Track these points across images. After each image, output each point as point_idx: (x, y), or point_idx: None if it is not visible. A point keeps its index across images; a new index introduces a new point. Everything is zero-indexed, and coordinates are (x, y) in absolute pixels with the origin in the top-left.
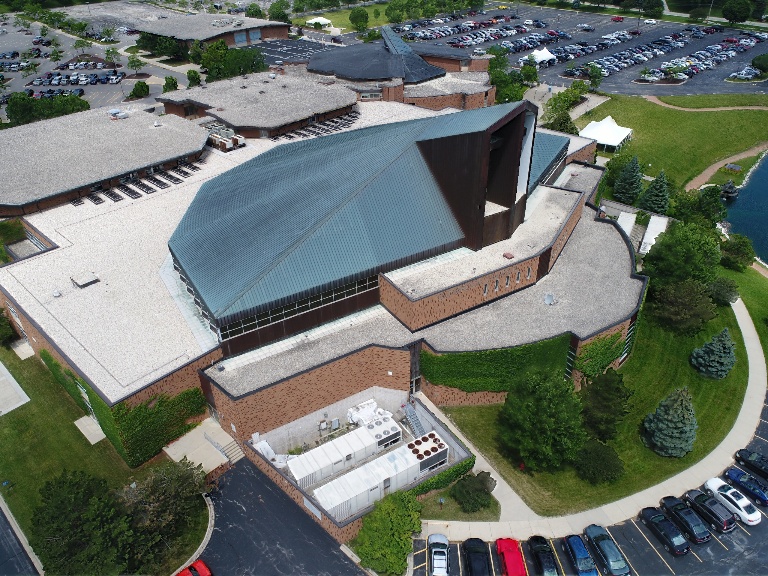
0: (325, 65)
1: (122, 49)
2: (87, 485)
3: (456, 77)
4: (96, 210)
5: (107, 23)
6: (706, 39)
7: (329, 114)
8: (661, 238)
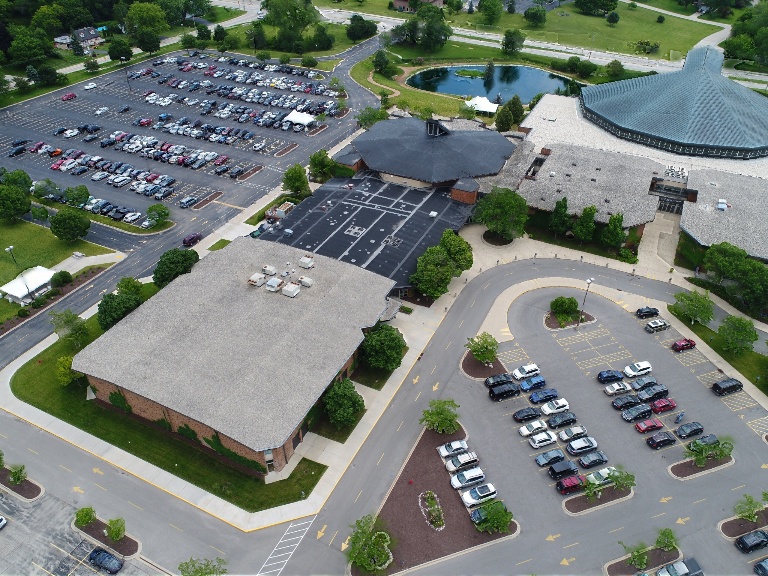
0: (490, 162)
1: (287, 513)
2: None
3: None
4: None
5: None
6: (178, 75)
7: None
8: None
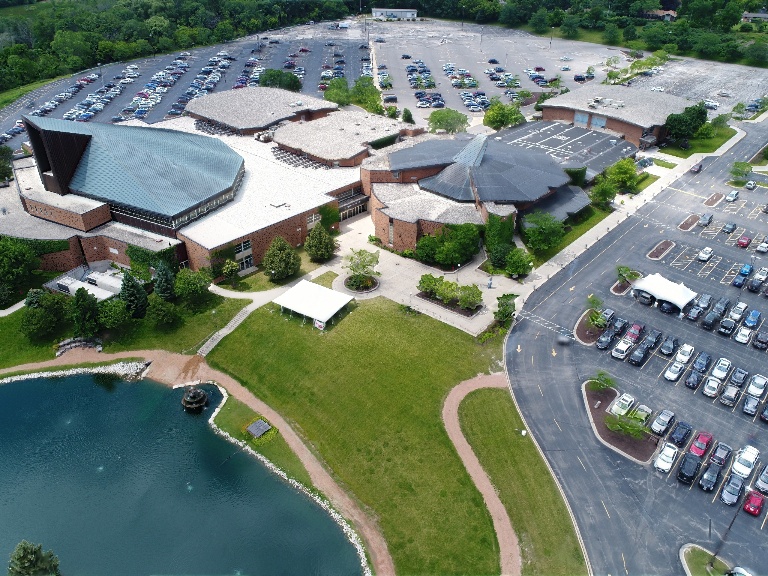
0: None
1: None
2: (5, 152)
3: (455, 207)
4: (187, 125)
5: (677, 82)
6: None
7: (315, 157)
8: (20, 243)
